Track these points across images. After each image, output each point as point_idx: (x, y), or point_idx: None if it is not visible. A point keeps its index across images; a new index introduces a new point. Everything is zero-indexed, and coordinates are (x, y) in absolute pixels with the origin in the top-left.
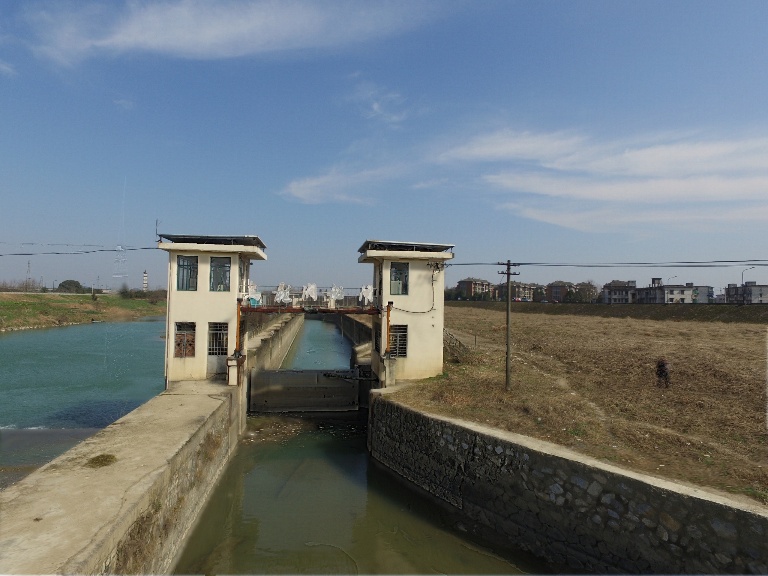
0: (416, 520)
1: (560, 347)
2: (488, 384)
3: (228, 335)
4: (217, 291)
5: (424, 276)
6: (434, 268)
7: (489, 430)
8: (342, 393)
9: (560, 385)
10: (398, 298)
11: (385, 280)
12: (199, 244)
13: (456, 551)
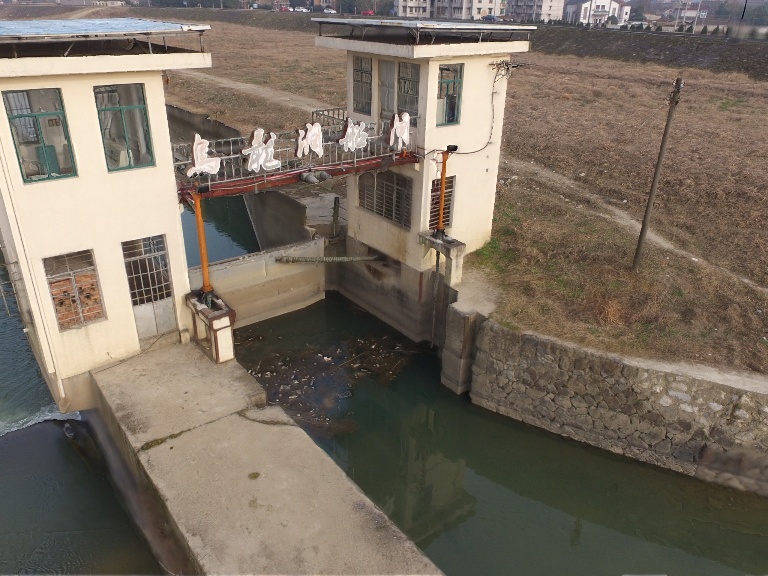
0: (588, 484)
1: (512, 137)
2: (598, 263)
3: (169, 259)
4: (126, 169)
5: (483, 86)
6: (499, 71)
7: (750, 381)
8: (304, 281)
9: (656, 241)
10: (446, 132)
11: (430, 101)
12: (67, 58)
13: (671, 517)
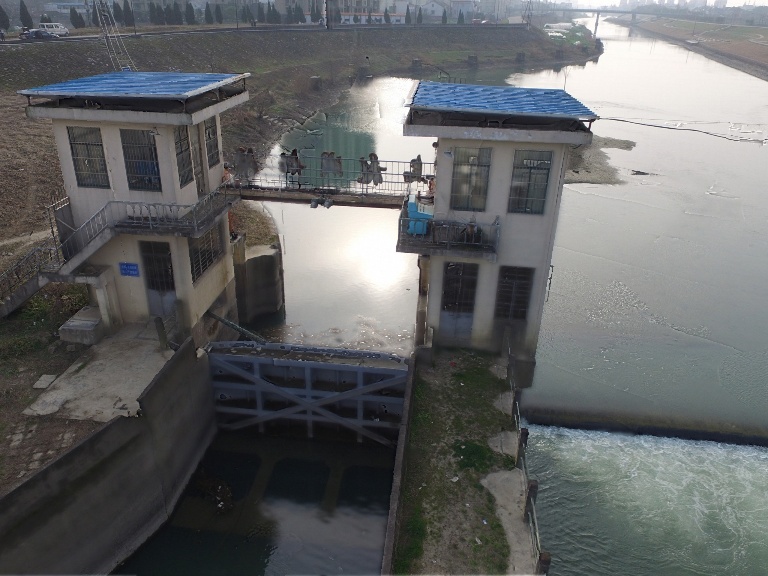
0: None
1: None
2: None
3: None
4: None
5: None
6: None
7: (252, 201)
8: None
9: None
10: None
11: None
12: None
13: None
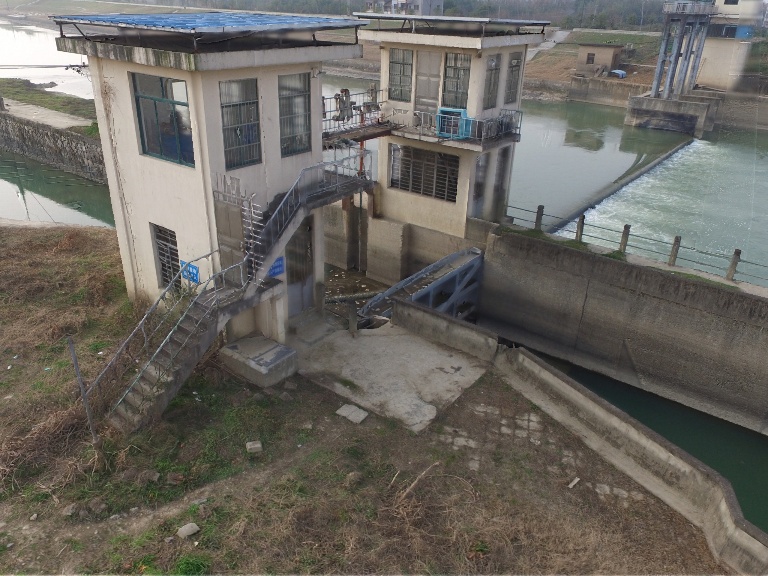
0: None
1: None
2: (22, 274)
3: None
4: None
5: None
6: None
7: (17, 223)
8: None
9: None
10: None
11: None
12: None
13: None
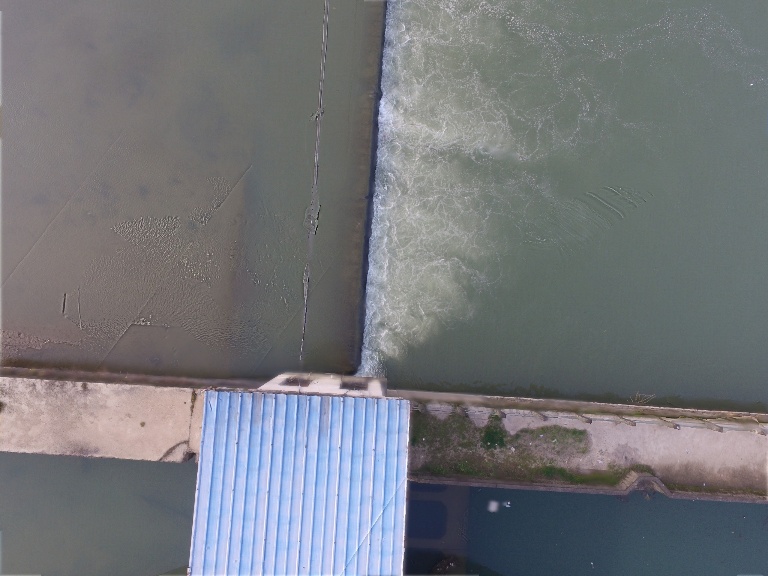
0: None
1: None
2: None
3: None
4: None
5: None
6: None
7: None
8: None
9: None
10: None
11: None
12: None
13: None
